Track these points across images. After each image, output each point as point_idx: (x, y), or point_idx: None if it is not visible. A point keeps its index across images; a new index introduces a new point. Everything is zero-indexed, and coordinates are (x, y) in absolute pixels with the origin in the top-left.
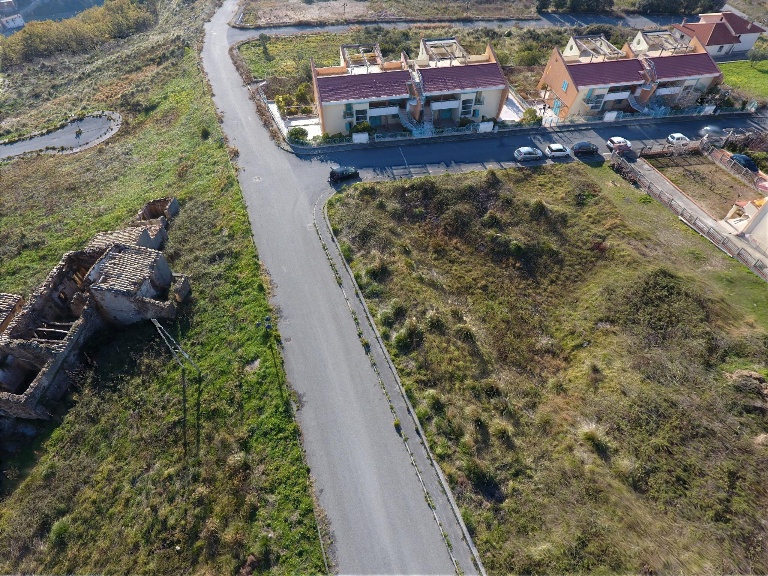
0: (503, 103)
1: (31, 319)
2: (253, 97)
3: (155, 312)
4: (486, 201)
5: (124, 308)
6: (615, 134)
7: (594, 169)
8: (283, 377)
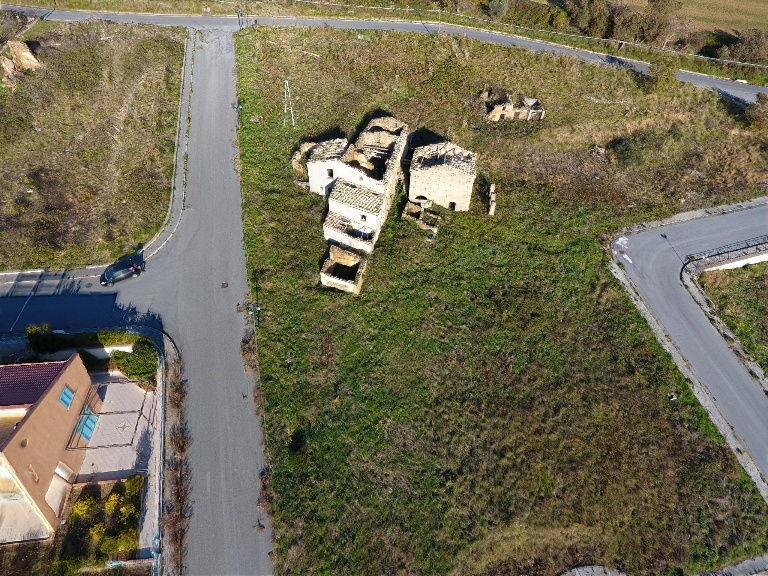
0: None
1: None
2: None
3: None
4: (1, 222)
5: None
6: None
7: None
8: None
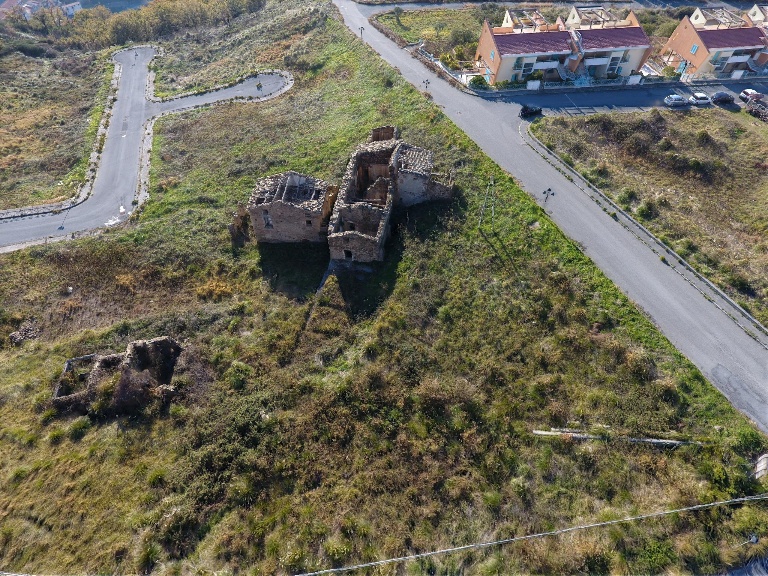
0: (645, 61)
1: (346, 196)
2: (415, 56)
3: (438, 194)
4: (657, 132)
5: (414, 190)
6: (743, 89)
7: (734, 114)
8: (562, 232)
